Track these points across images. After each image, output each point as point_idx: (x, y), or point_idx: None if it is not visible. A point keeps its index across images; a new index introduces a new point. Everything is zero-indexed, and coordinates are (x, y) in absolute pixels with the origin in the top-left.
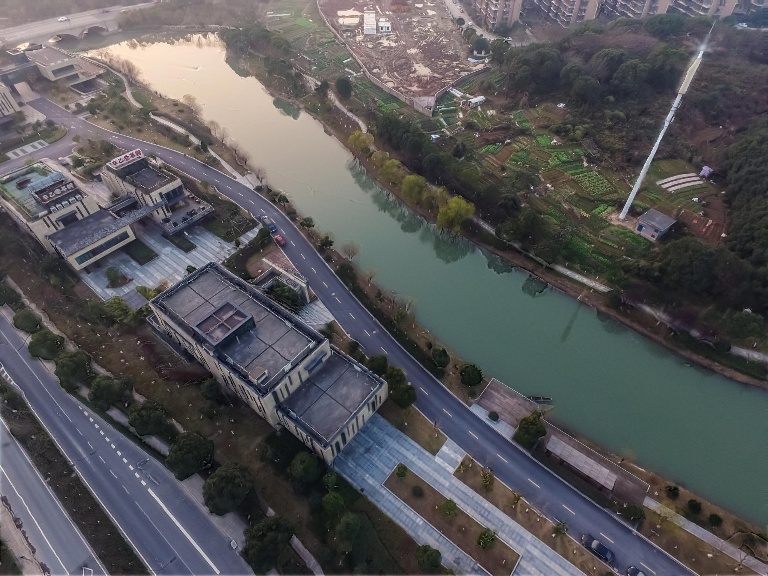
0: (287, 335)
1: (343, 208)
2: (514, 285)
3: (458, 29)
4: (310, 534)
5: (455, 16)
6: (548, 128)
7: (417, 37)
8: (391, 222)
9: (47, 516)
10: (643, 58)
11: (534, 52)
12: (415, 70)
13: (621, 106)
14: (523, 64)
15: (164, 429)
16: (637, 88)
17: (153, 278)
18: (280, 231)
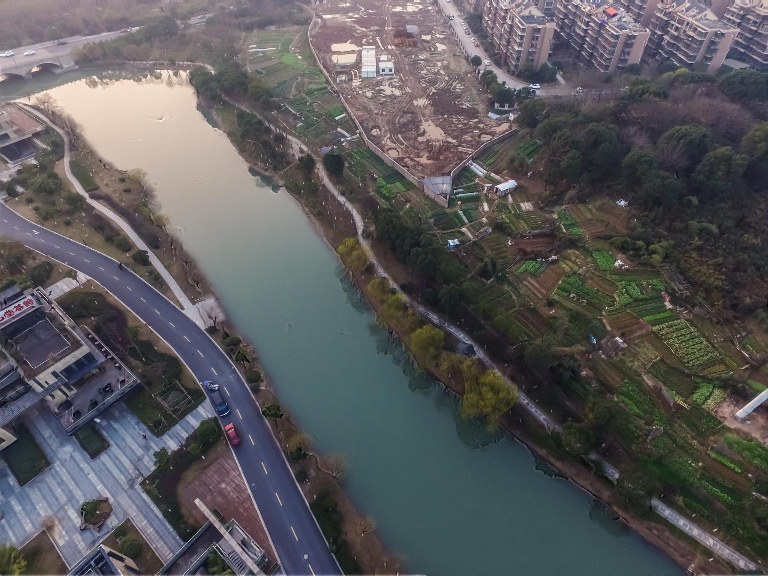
0: None
1: (329, 353)
2: (575, 502)
3: (474, 71)
4: None
5: (469, 53)
6: (608, 240)
7: (425, 82)
8: (394, 371)
9: None
10: (736, 144)
11: (585, 129)
12: (424, 131)
13: (708, 211)
14: (571, 147)
15: None
16: (729, 186)
17: (34, 515)
18: (234, 414)
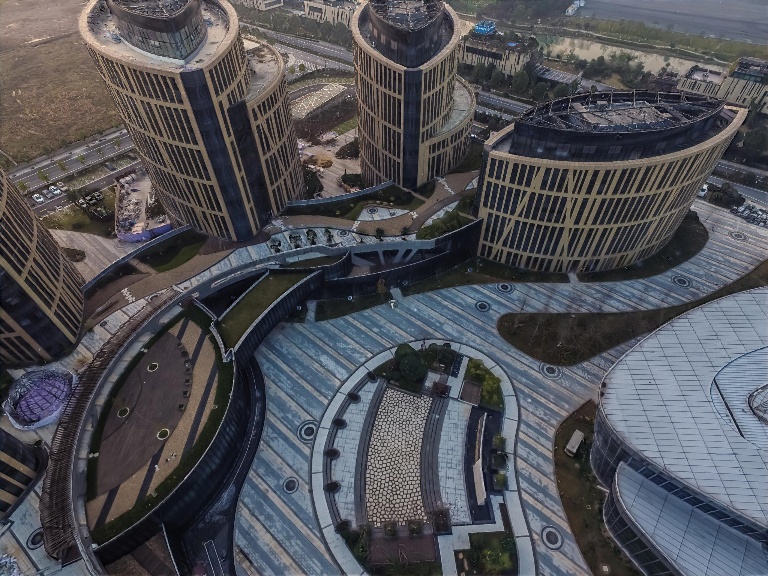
0: (355, 5)
1: None
2: None
3: None
4: None
5: None
6: None
7: None
8: None
9: (282, 47)
10: None
11: None
12: None
13: None
14: None
15: (315, 30)
16: None
17: None
18: None
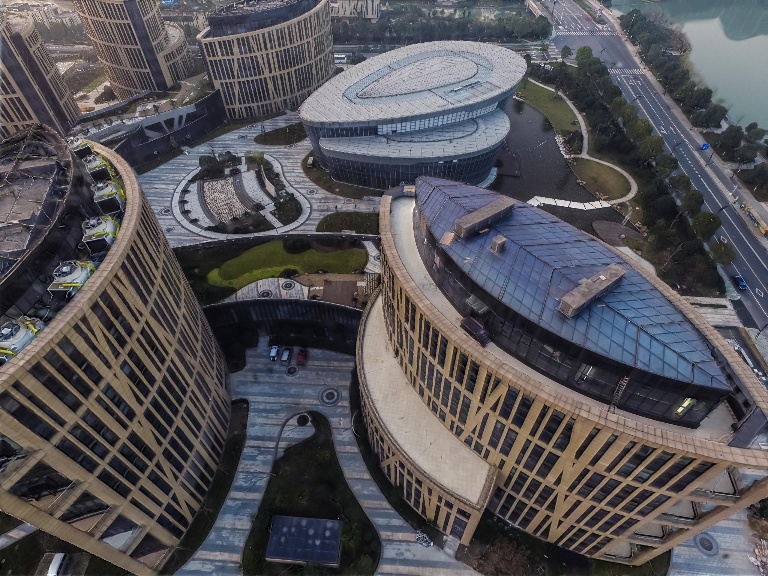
0: (42, 7)
1: None
2: None
3: None
4: (72, 39)
5: None
6: None
7: None
8: None
9: None
10: None
11: None
12: None
13: None
14: None
15: None
16: None
17: None
18: None
